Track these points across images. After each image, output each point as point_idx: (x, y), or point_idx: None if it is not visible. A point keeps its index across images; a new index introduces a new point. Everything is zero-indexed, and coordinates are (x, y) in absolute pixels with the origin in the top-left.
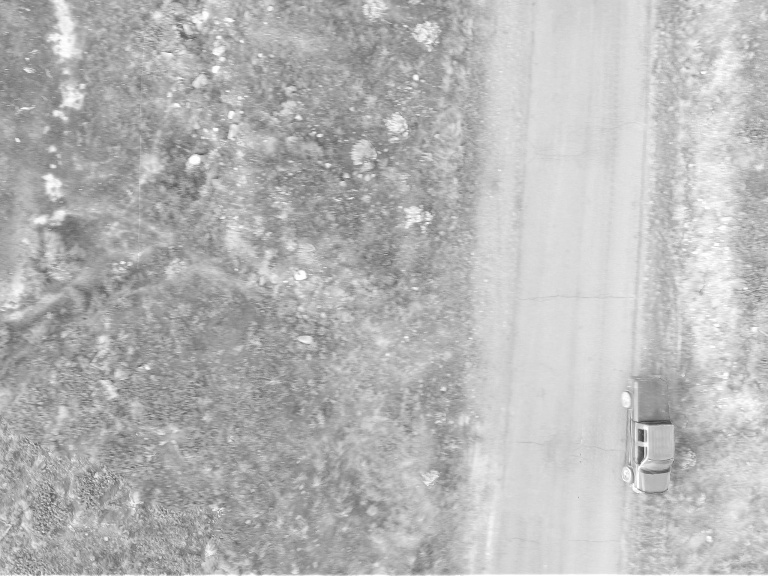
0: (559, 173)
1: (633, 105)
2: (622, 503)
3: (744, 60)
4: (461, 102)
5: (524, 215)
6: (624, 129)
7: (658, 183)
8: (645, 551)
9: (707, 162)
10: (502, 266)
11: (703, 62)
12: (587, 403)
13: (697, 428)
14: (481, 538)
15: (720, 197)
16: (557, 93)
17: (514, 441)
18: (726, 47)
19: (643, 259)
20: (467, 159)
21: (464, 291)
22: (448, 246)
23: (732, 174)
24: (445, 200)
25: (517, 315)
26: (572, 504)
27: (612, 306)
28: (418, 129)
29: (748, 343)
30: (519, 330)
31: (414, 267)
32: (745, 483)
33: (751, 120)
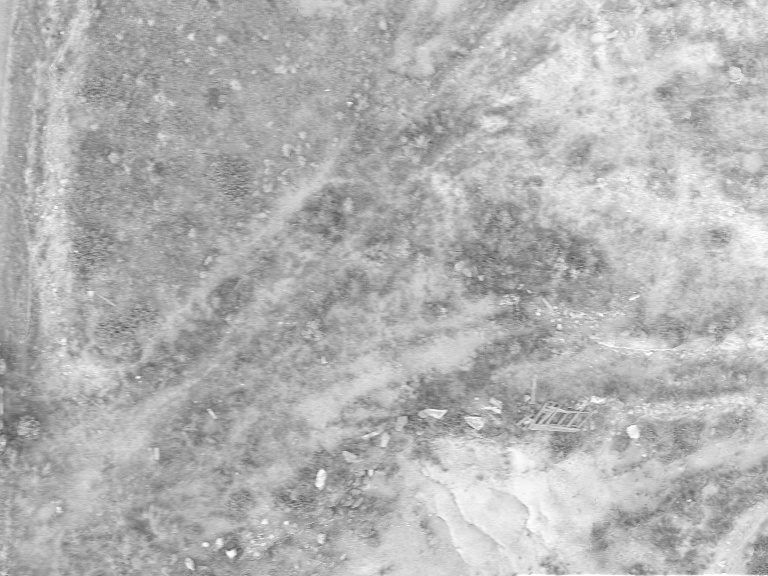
0: None
1: None
2: None
3: (92, 18)
4: None
5: None
6: None
7: (11, 146)
8: None
9: (54, 124)
10: None
11: (60, 22)
12: None
13: (46, 396)
14: None
15: (60, 159)
16: None
17: None
18: (82, 6)
19: None
20: None
21: None
22: None
23: (70, 135)
24: None
25: None
26: None
27: None
28: None
29: (85, 308)
30: None
31: None
32: (97, 452)
33: (90, 79)
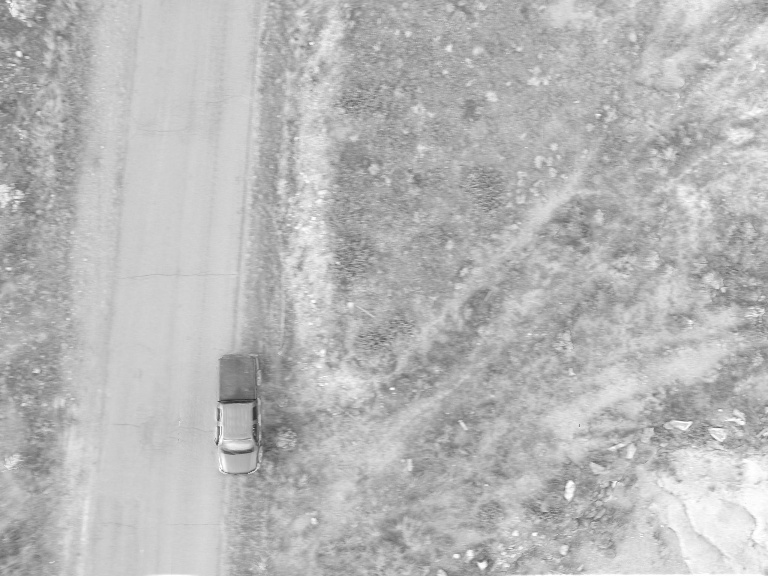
0: (161, 149)
1: (239, 78)
2: (222, 485)
3: (346, 29)
4: (63, 78)
5: (124, 192)
6: (229, 103)
7: (262, 157)
8: (245, 534)
9: (308, 135)
10: (101, 245)
11: (310, 33)
12: (185, 383)
13: (301, 407)
14: (76, 523)
15: (317, 170)
16: (162, 67)
17: (110, 423)
18: (332, 17)
19: (246, 235)
20: (68, 136)
21: (62, 271)
22: (44, 225)
23: (328, 146)
24: (42, 178)
25: (115, 294)
26: (169, 487)
27: (213, 284)
28: (18, 106)
29: (344, 319)
30: (117, 310)
31: (6, 247)
32: (352, 463)
33: (348, 90)
